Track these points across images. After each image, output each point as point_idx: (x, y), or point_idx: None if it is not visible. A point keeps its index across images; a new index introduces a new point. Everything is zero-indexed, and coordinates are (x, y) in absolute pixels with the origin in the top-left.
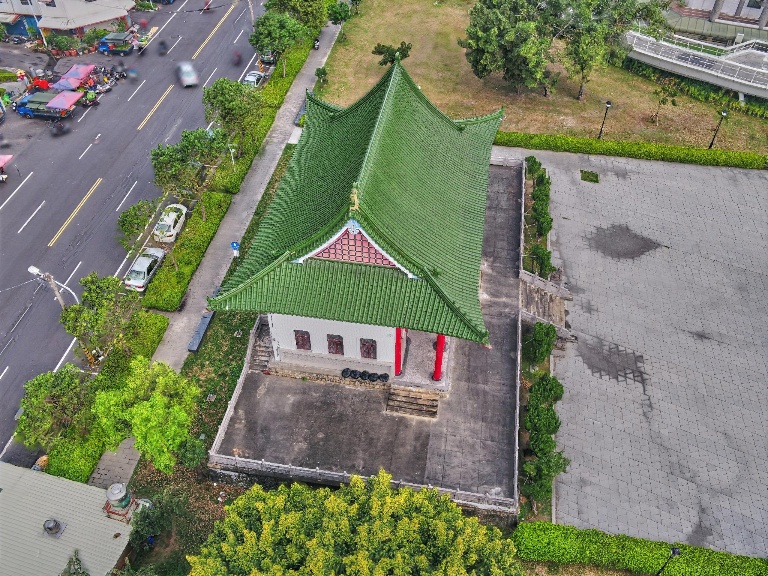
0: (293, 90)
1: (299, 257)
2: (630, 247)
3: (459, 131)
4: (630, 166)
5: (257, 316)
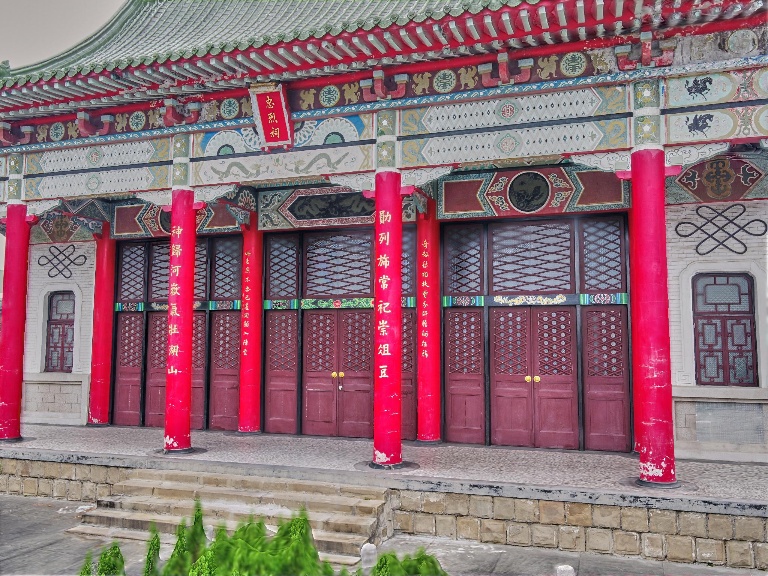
0: None
1: None
2: None
3: None
4: None
5: None
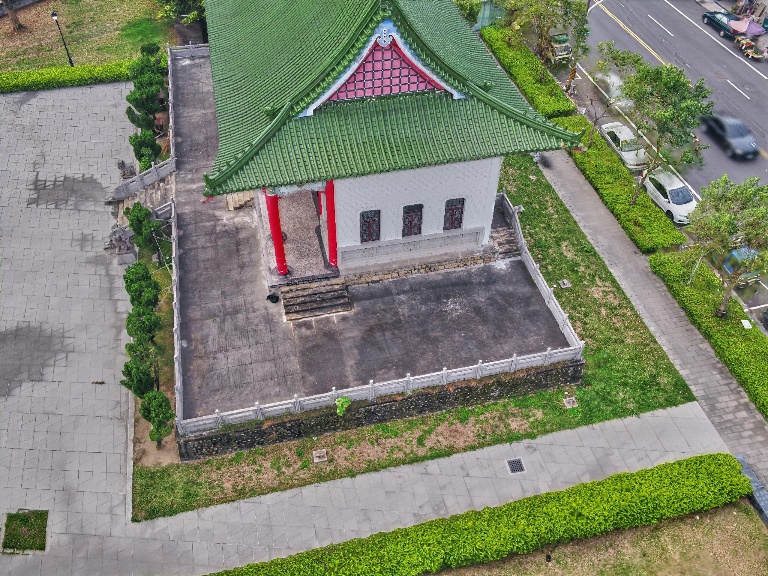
0: None
1: None
2: None
3: None
4: None
5: None
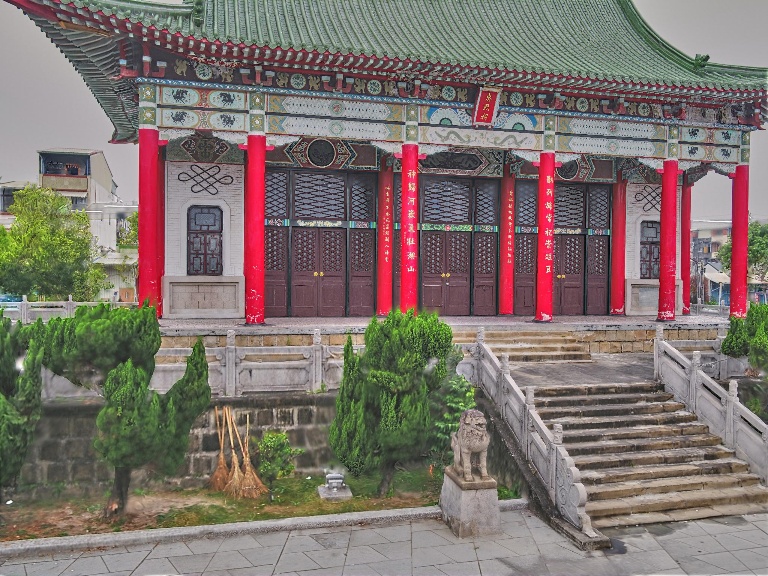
0: None
1: None
2: None
3: (693, 72)
4: None
5: None
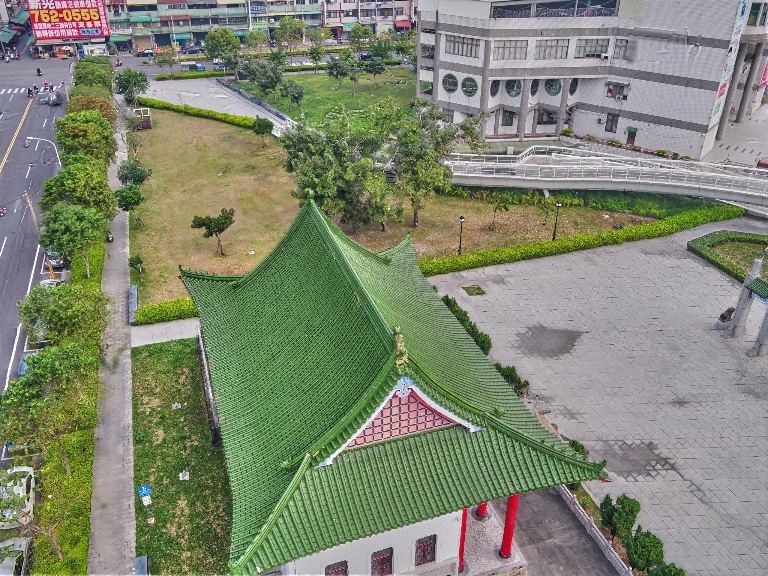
0: (106, 289)
1: (328, 456)
2: (558, 343)
3: (386, 264)
4: (501, 272)
5: (215, 575)
